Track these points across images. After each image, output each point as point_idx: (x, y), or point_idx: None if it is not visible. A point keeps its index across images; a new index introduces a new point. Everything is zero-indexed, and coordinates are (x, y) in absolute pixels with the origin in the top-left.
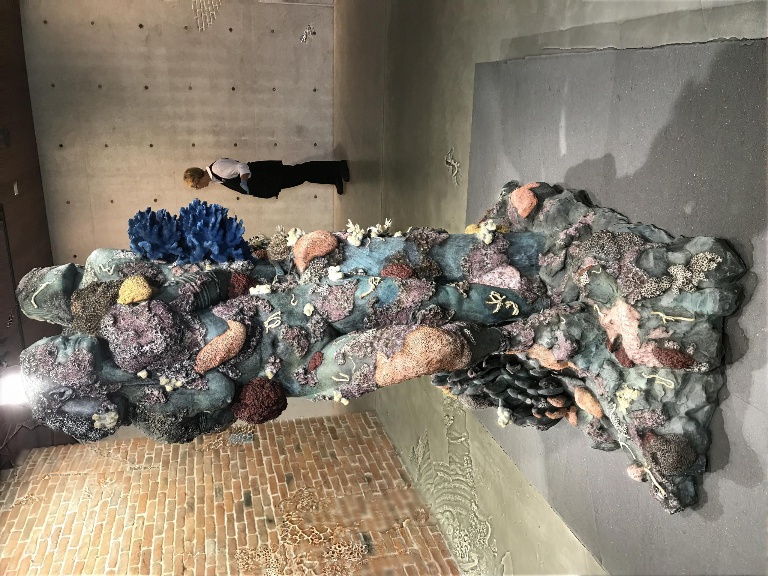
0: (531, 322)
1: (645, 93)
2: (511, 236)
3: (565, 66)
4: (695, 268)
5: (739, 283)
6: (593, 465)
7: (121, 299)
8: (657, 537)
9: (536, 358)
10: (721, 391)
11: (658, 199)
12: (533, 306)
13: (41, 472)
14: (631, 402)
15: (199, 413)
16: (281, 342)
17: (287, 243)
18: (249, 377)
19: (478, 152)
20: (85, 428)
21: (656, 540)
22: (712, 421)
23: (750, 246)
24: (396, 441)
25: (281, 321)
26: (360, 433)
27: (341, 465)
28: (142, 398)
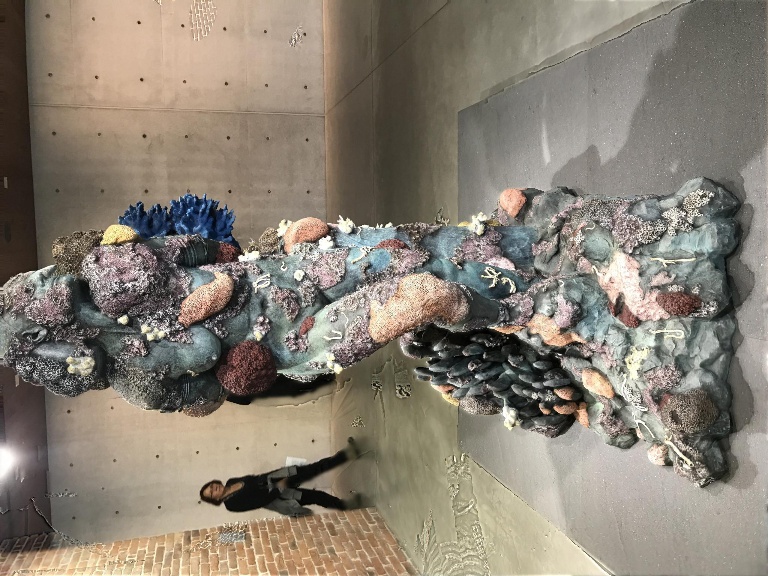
0: (529, 291)
1: (619, 77)
2: (503, 229)
3: (542, 82)
4: (688, 207)
5: (735, 219)
6: (611, 473)
7: (105, 240)
8: (690, 530)
9: (538, 333)
10: (734, 337)
11: (644, 170)
12: (530, 285)
13: (10, 568)
14: (642, 362)
15: (182, 379)
16: (270, 303)
17: (278, 233)
18: (236, 339)
19: (466, 192)
20: (58, 373)
21: (689, 535)
22: (730, 373)
23: (740, 180)
24: (399, 534)
25: (270, 282)
26: (360, 528)
27: (340, 560)
28: (121, 351)
